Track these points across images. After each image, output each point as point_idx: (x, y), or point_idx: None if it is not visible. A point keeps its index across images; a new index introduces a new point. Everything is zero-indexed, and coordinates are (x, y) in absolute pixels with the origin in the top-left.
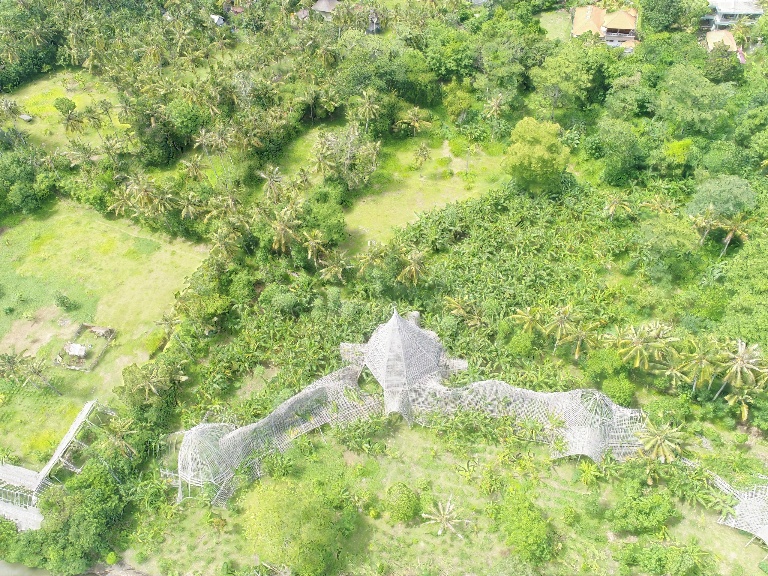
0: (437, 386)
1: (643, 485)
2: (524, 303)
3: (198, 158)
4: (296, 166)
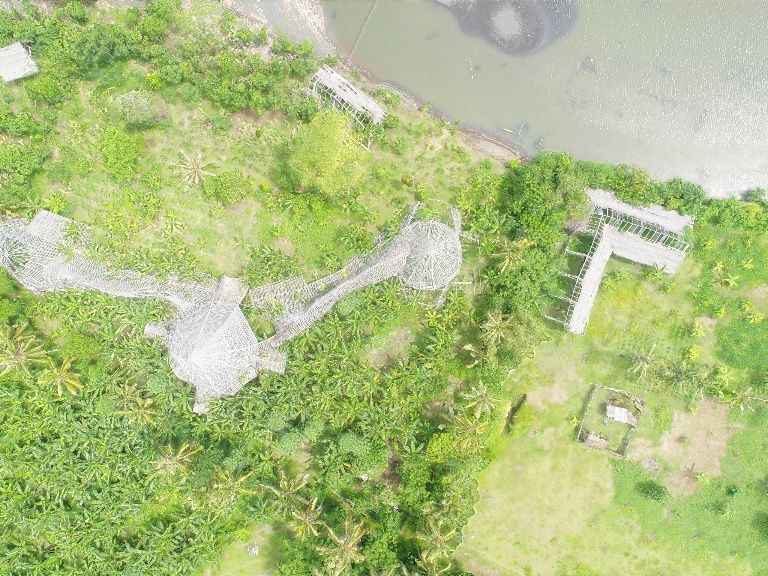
0: (180, 302)
1: (8, 187)
2: (68, 410)
3: None
4: None
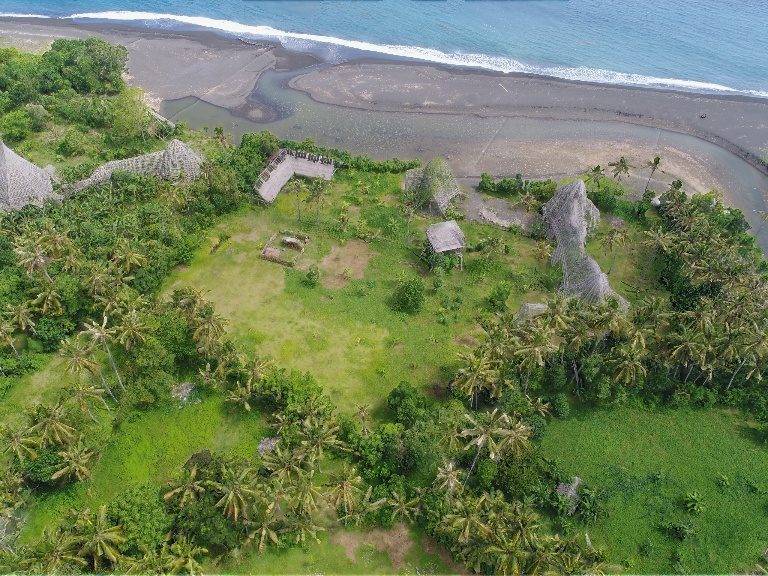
0: None
1: None
2: None
3: (119, 327)
4: (3, 464)
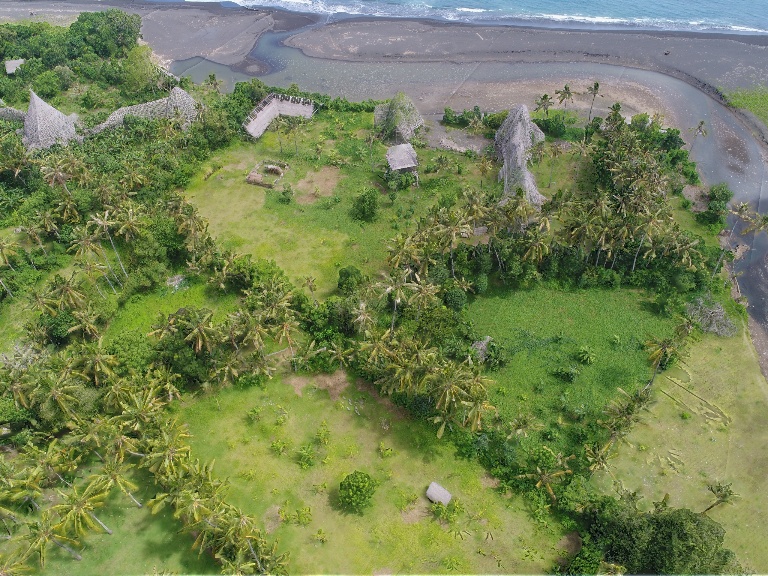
0: None
1: None
2: None
3: None
4: None
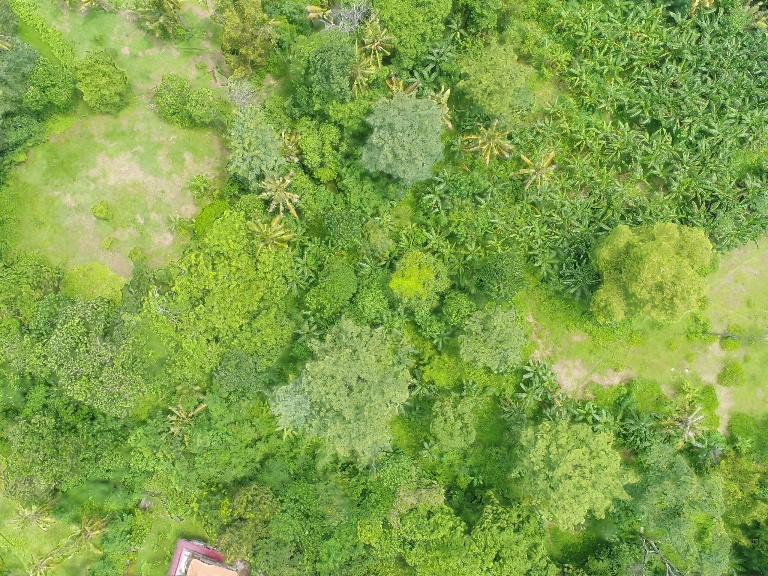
0: None
1: None
2: None
3: None
4: None
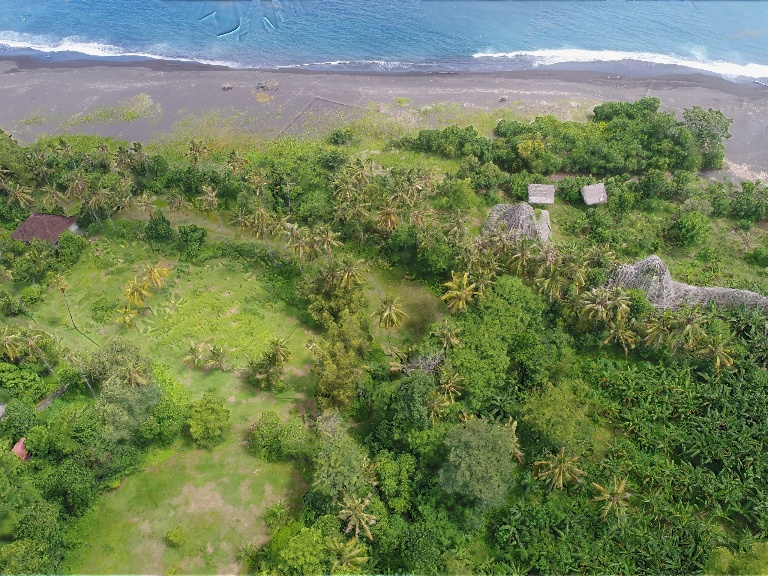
0: None
1: None
2: None
3: None
4: None
